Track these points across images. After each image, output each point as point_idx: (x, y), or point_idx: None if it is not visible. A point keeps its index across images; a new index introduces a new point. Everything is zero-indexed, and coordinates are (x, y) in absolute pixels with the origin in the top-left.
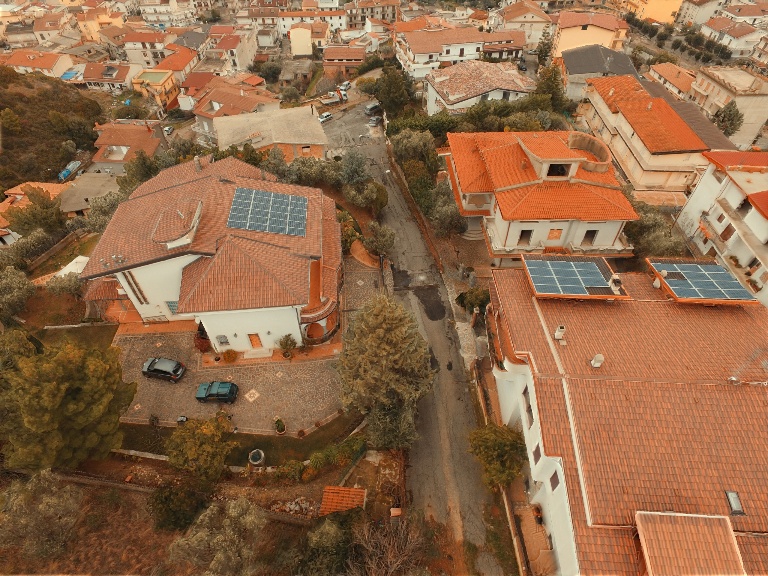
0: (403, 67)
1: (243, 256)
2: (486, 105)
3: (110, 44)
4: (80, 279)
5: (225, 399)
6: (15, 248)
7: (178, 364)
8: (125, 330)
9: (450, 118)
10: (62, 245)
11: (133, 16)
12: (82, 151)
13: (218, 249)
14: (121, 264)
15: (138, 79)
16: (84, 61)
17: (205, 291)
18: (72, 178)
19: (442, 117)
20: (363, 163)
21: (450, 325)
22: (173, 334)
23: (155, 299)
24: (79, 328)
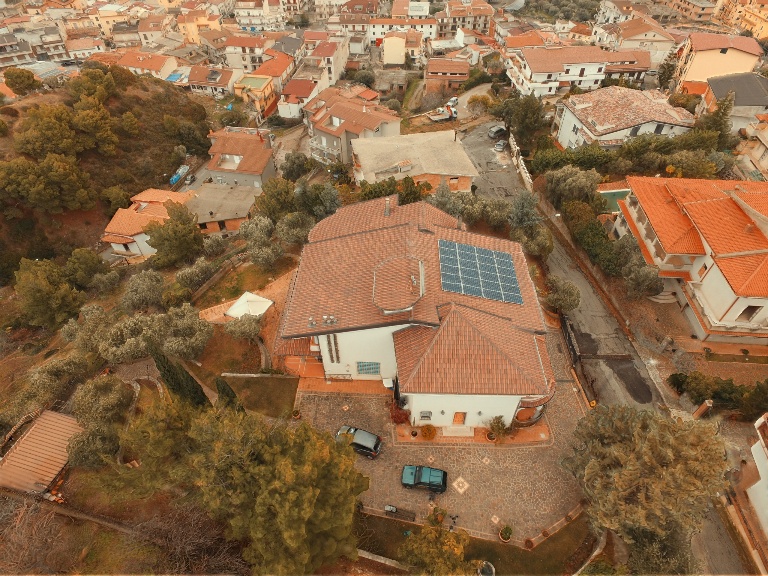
0: (513, 84)
1: (471, 330)
2: (645, 140)
3: (209, 47)
4: (285, 337)
5: (436, 489)
6: (180, 277)
7: (377, 438)
8: (306, 386)
9: (604, 152)
10: (220, 275)
11: (227, 18)
12: (190, 155)
13: (442, 319)
14: (331, 325)
15: (240, 84)
16: (187, 63)
17: (431, 369)
18: (181, 183)
19: (595, 151)
20: (533, 205)
21: (663, 412)
22: (359, 396)
23: (348, 359)
24: (258, 378)
